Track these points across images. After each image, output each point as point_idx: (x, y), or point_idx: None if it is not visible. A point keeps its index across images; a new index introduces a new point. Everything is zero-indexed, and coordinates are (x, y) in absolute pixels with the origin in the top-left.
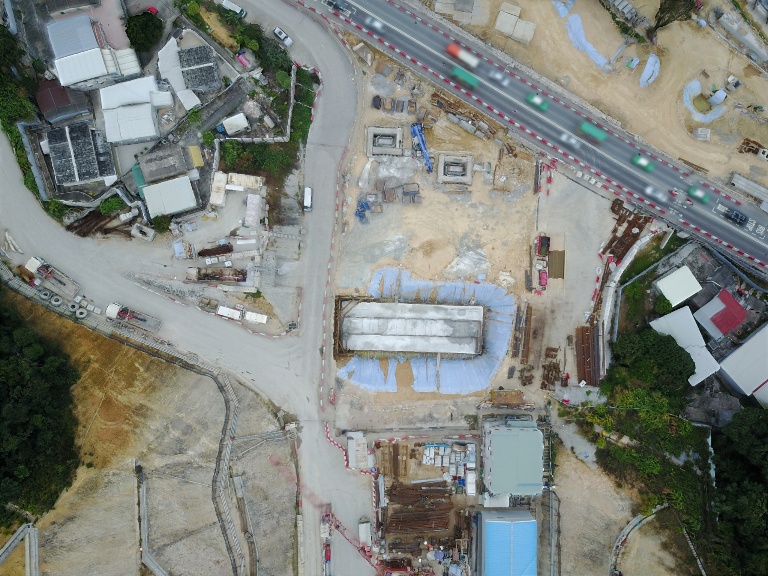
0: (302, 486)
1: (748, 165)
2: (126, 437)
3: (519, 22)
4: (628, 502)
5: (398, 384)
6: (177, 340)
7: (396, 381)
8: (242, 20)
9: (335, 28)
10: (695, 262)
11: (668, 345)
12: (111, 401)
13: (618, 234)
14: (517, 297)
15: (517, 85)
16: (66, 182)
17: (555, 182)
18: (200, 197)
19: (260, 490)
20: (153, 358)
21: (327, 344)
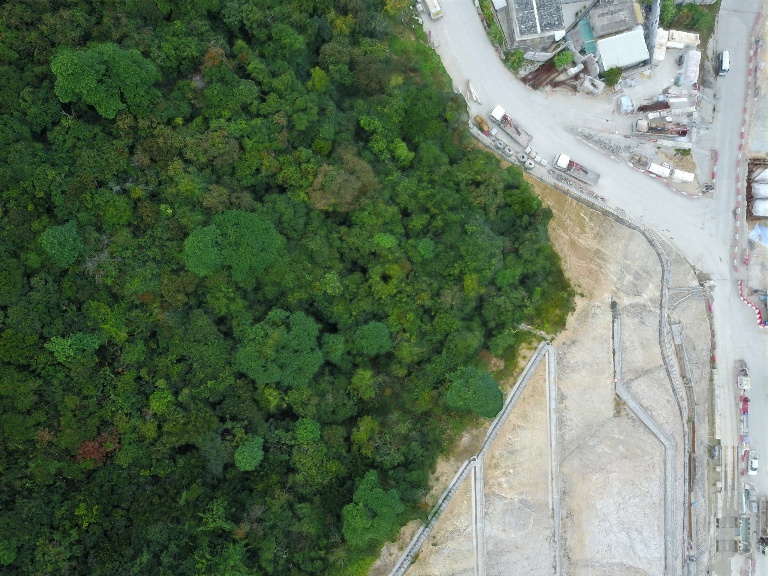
0: None
1: None
2: (597, 275)
3: None
4: None
5: None
6: (607, 195)
7: None
8: None
9: None
10: None
11: None
12: (575, 243)
13: None
14: None
15: None
16: (528, 33)
17: None
18: None
19: (690, 340)
20: (592, 210)
21: (741, 206)
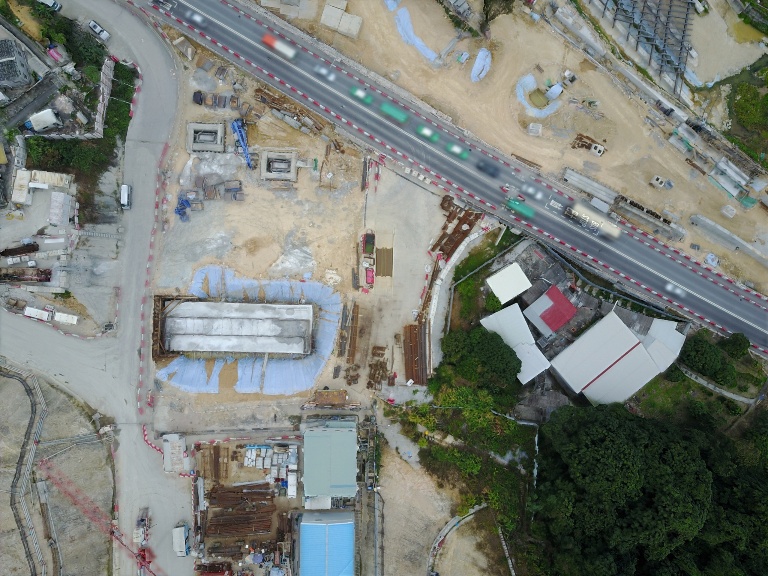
0: (119, 490)
1: (582, 161)
2: None
3: (344, 16)
4: (448, 502)
5: (220, 385)
6: None
7: (218, 382)
8: (57, 13)
9: (154, 22)
10: (529, 259)
11: (491, 343)
12: None
13: (448, 231)
14: (343, 295)
15: (344, 80)
16: None
17: (384, 178)
18: (2, 195)
19: (68, 495)
20: None
21: (145, 345)
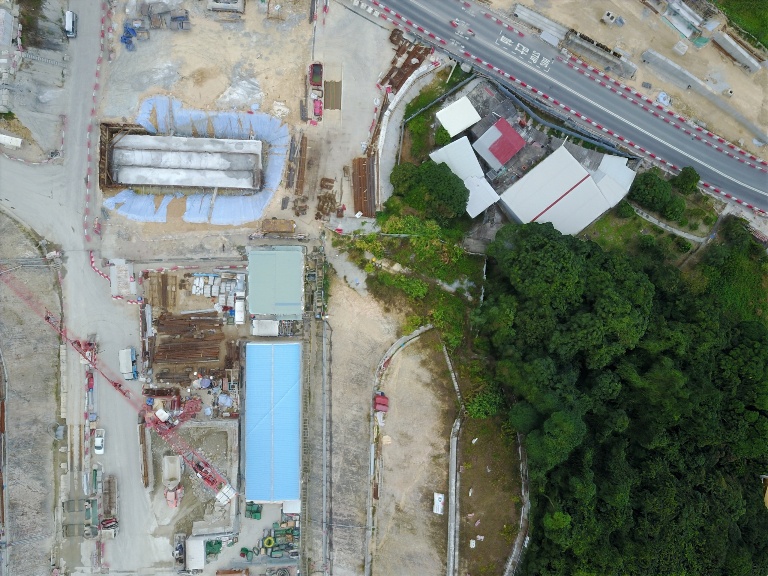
0: (67, 316)
1: None
2: None
3: None
4: (394, 325)
5: (168, 215)
6: None
7: (166, 212)
8: None
9: None
10: (480, 96)
11: (438, 170)
12: None
13: (398, 65)
14: (292, 127)
15: None
16: None
17: (332, 11)
18: None
19: (13, 314)
20: None
21: (92, 173)
